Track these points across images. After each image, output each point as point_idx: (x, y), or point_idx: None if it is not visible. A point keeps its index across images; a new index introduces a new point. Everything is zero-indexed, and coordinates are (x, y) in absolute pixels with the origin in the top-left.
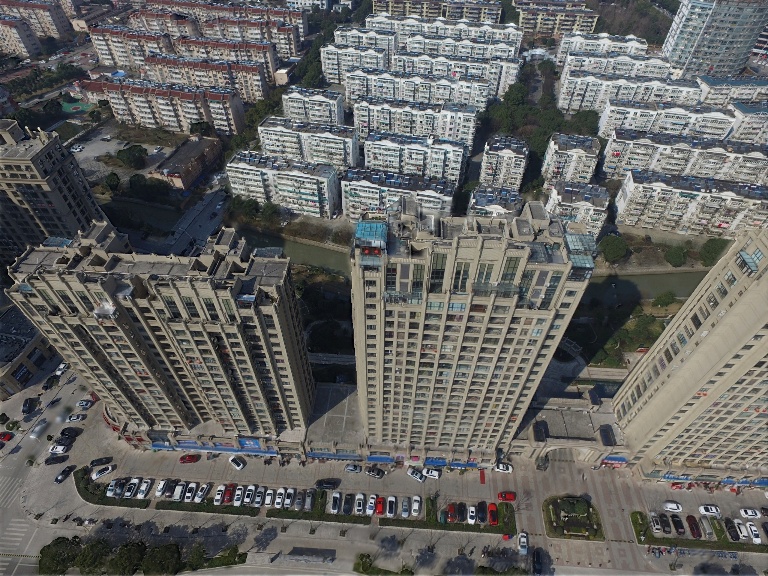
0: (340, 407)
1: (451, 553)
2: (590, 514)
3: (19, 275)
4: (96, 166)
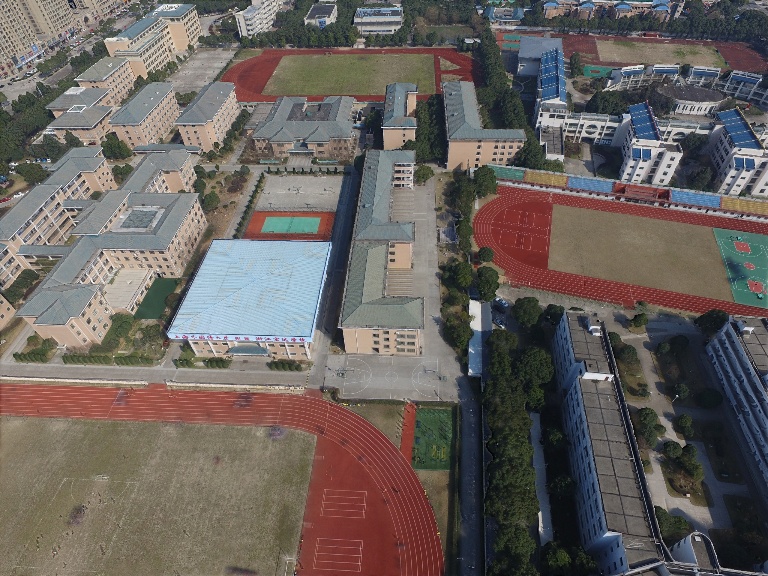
0: None
1: None
2: None
3: None
4: None
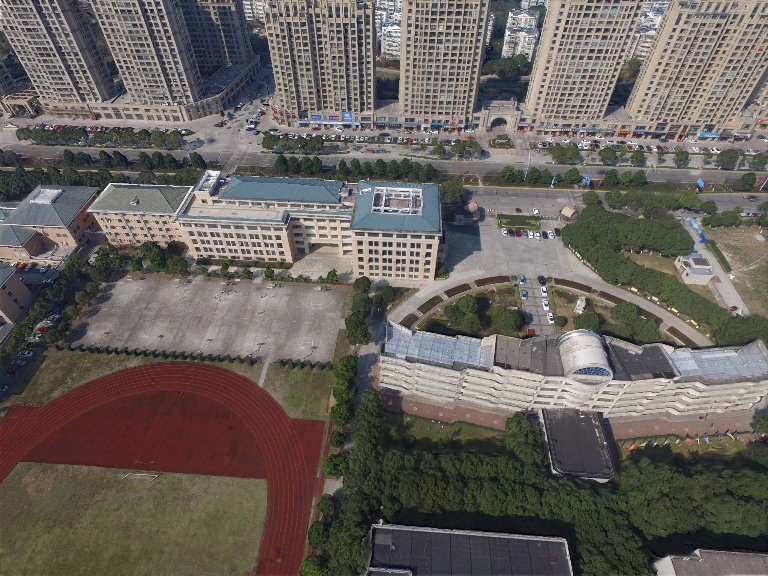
0: (389, 106)
1: None
2: (510, 142)
3: (267, 1)
4: None
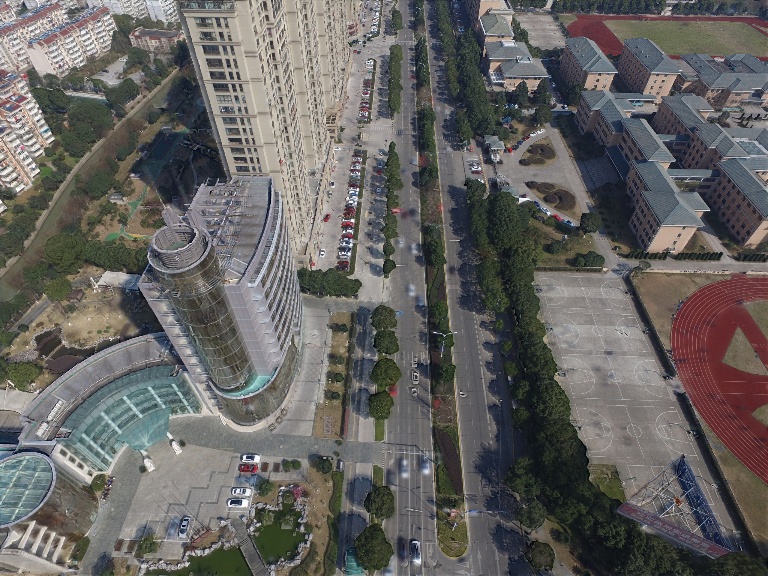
0: None
1: None
2: None
3: None
4: (135, 75)
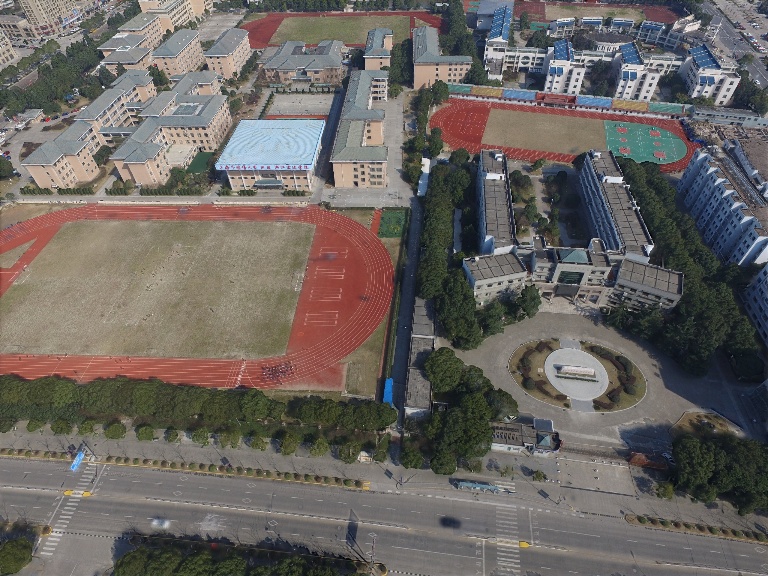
0: None
1: (126, 5)
2: None
3: None
4: None
